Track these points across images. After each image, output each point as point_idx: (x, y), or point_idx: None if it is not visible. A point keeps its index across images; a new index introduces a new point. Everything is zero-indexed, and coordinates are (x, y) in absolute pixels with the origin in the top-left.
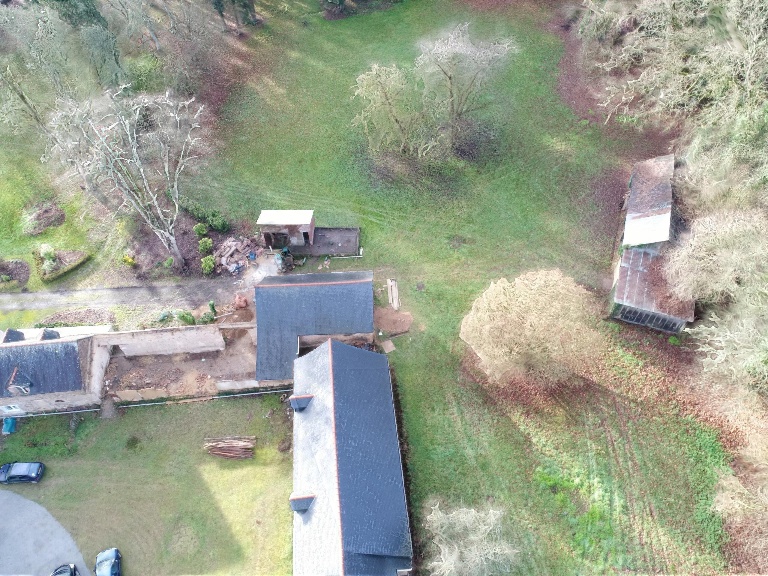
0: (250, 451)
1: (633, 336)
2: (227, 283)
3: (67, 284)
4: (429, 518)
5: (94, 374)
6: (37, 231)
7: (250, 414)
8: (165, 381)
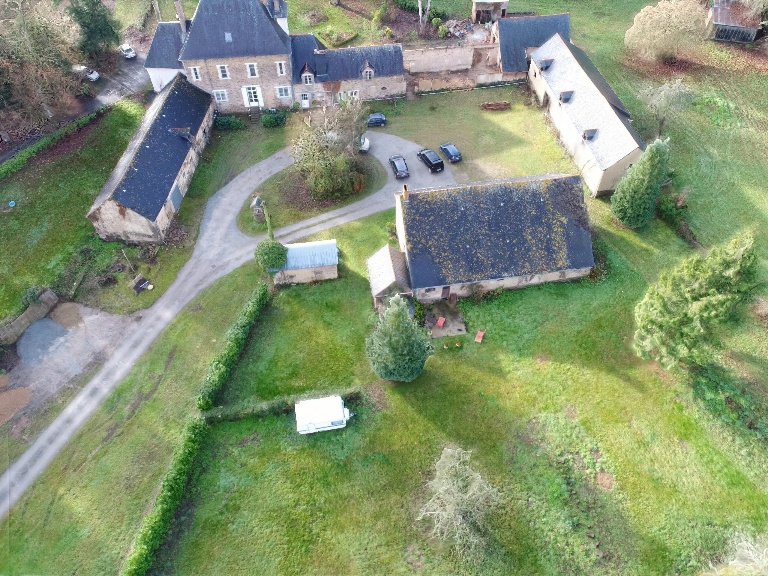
0: (508, 105)
1: (724, 45)
2: None
3: None
4: (639, 95)
5: None
6: (314, 24)
7: (500, 93)
8: None
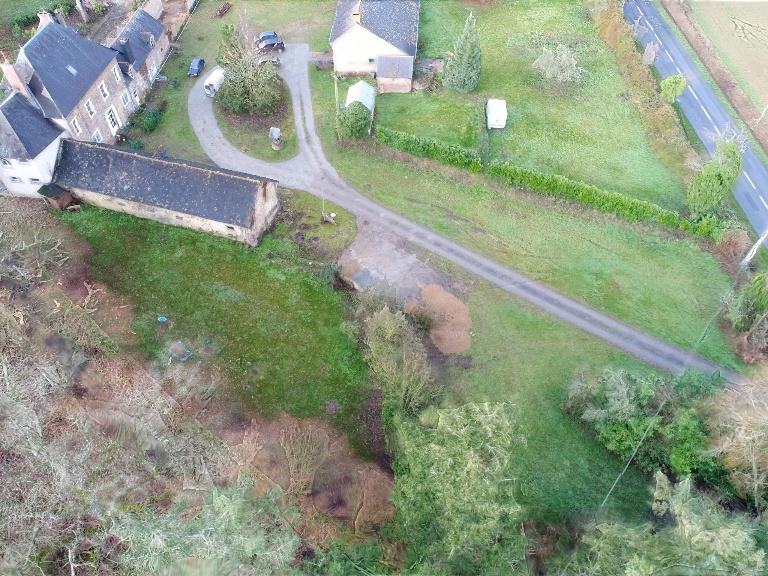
0: (228, 4)
1: None
2: (116, 8)
3: None
4: None
5: None
6: None
7: (208, 5)
8: None
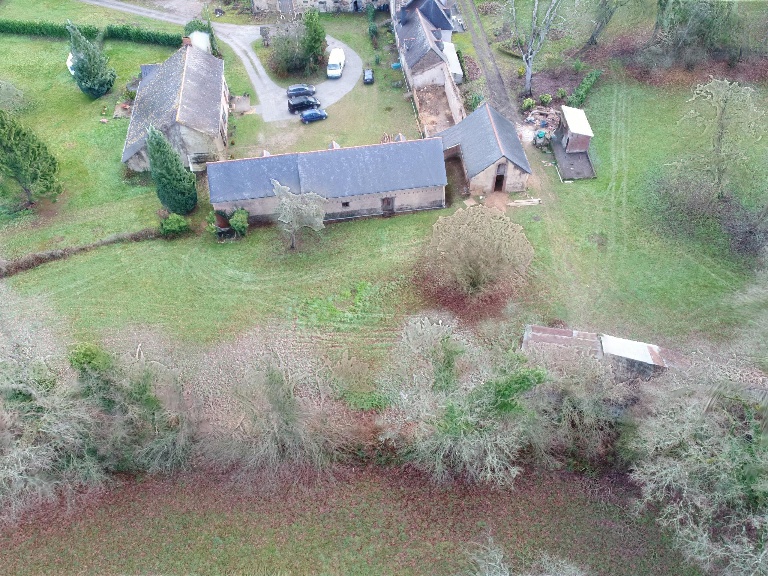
0: None
1: None
2: (516, 119)
3: (499, 57)
4: None
5: (424, 75)
6: None
7: None
8: (429, 109)
